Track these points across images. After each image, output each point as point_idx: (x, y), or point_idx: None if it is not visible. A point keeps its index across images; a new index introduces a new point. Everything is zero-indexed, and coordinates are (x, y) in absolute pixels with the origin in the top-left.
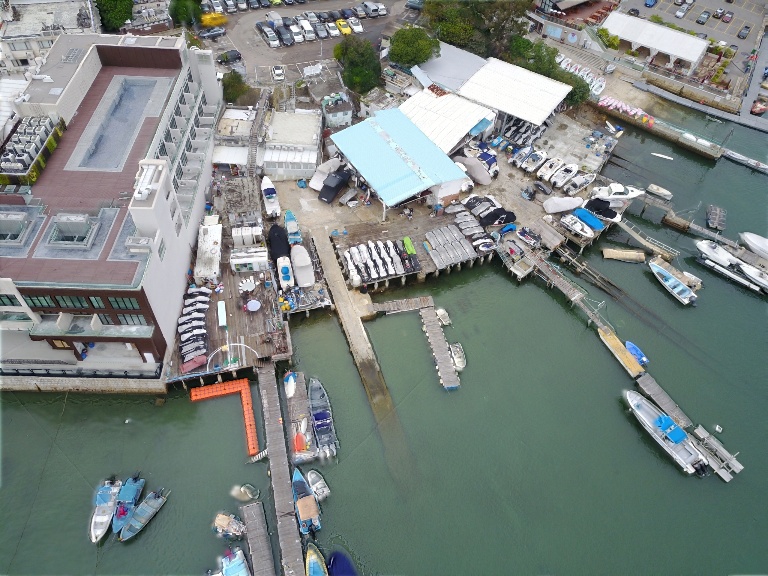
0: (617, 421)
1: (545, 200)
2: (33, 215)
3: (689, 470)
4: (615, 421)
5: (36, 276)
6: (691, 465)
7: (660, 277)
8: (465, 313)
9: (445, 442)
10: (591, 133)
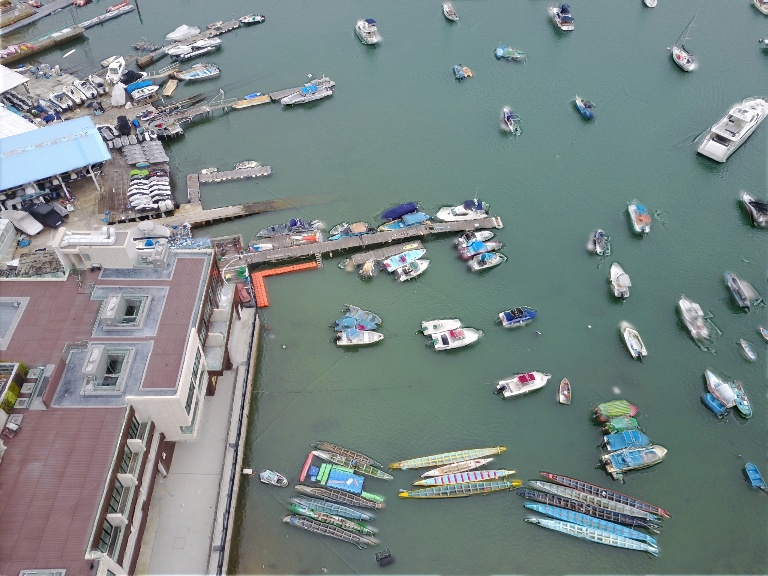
0: (297, 115)
1: (107, 105)
2: (84, 356)
3: (331, 93)
4: (296, 116)
5: (182, 325)
6: (328, 92)
7: (194, 76)
8: (205, 163)
9: (309, 179)
10: (31, 73)
